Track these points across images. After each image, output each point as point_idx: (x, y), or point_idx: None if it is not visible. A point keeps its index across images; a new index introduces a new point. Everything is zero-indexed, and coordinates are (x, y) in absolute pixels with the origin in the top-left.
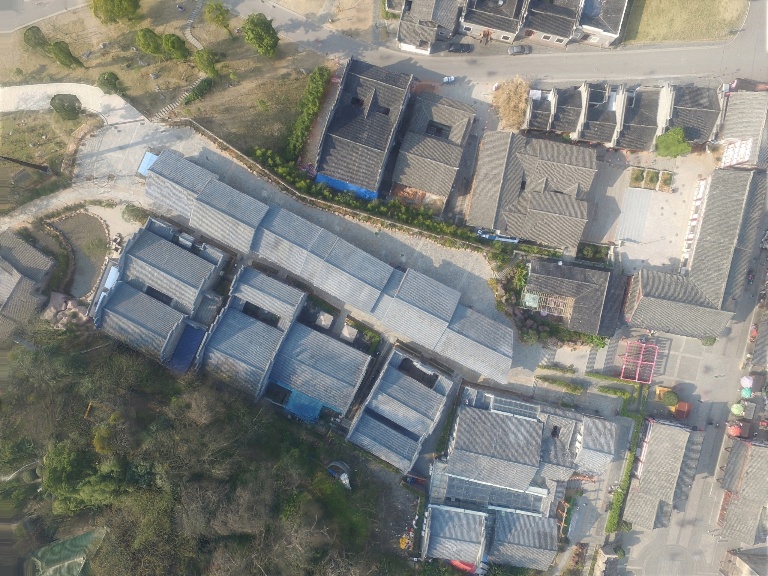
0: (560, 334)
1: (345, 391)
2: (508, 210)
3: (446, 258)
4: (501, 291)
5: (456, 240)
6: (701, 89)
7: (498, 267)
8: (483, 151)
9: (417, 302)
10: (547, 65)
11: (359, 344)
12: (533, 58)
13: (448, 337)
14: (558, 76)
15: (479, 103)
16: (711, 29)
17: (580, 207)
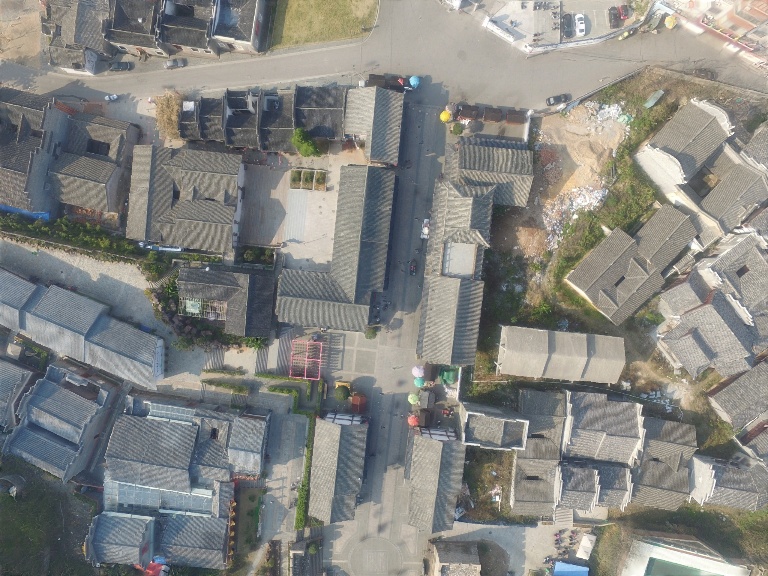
0: (223, 337)
1: (3, 407)
2: (160, 221)
3: (103, 272)
4: (154, 300)
5: (108, 254)
6: (330, 88)
7: (153, 277)
8: (134, 165)
9: (54, 317)
10: (203, 76)
11: (31, 360)
12: (190, 70)
13: (91, 349)
14: (214, 86)
15: (145, 118)
16: (346, 28)
17: (227, 212)
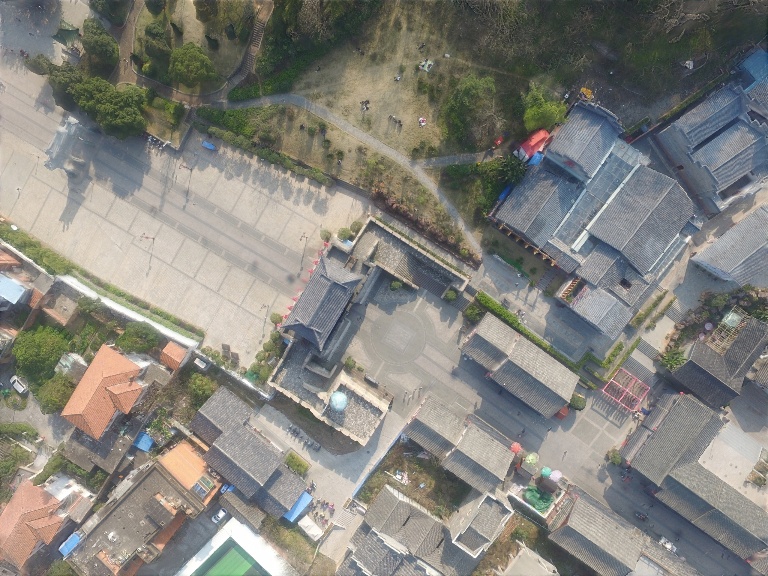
0: (691, 330)
1: None
2: None
3: None
4: (764, 294)
5: None
6: None
7: None
8: None
9: None
10: None
11: None
12: None
13: None
14: None
15: None
16: None
17: None
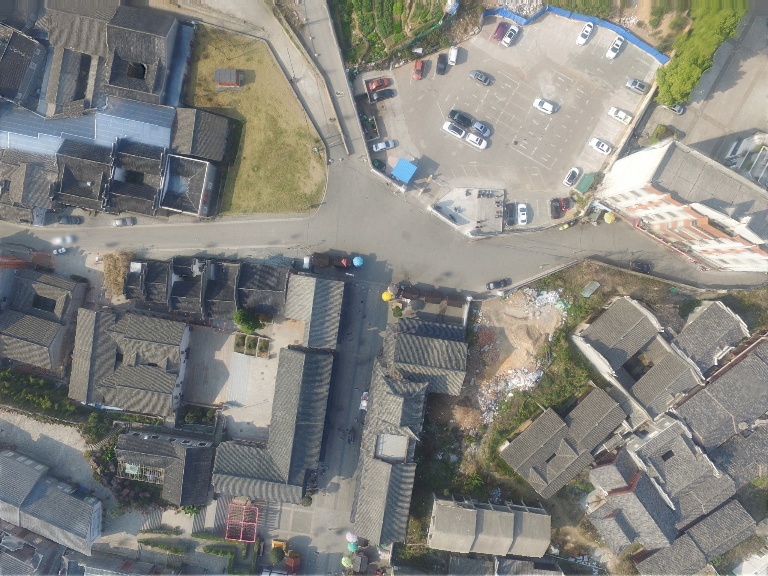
0: (161, 499)
1: None
2: (101, 384)
3: (43, 432)
4: (93, 464)
5: (48, 416)
6: (274, 267)
7: (92, 440)
8: (78, 327)
9: None
10: (152, 235)
11: None
12: (139, 229)
13: (26, 517)
14: (163, 246)
15: (93, 272)
16: (294, 203)
17: (168, 381)
